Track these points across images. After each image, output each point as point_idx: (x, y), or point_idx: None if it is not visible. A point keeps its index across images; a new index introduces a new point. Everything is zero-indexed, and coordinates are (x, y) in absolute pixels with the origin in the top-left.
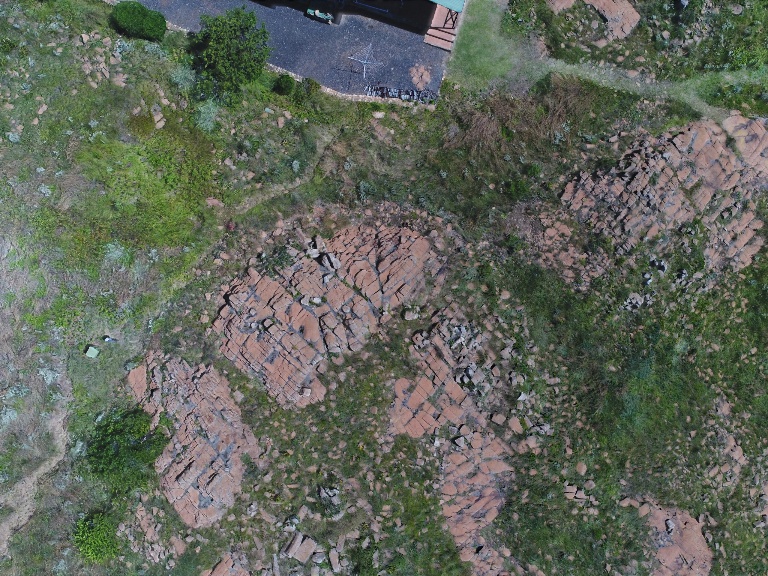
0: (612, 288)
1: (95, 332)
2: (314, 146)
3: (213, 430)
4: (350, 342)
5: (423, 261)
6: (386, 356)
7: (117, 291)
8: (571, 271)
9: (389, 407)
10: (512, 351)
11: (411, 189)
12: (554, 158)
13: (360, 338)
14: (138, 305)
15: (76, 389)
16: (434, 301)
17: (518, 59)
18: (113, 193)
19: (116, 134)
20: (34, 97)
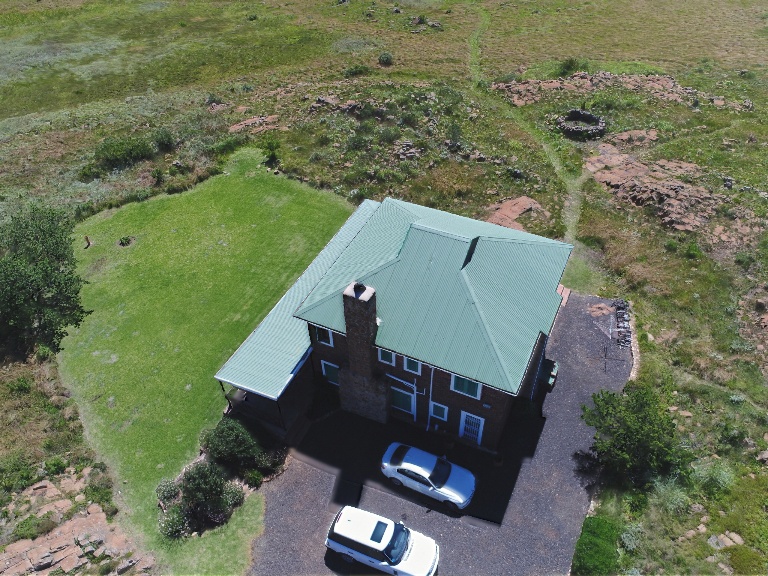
0: (761, 206)
1: None
2: None
3: None
4: None
5: None
6: None
7: None
8: (754, 228)
9: None
10: None
11: None
12: None
13: None
14: None
15: None
16: None
17: None
18: None
19: None
20: None
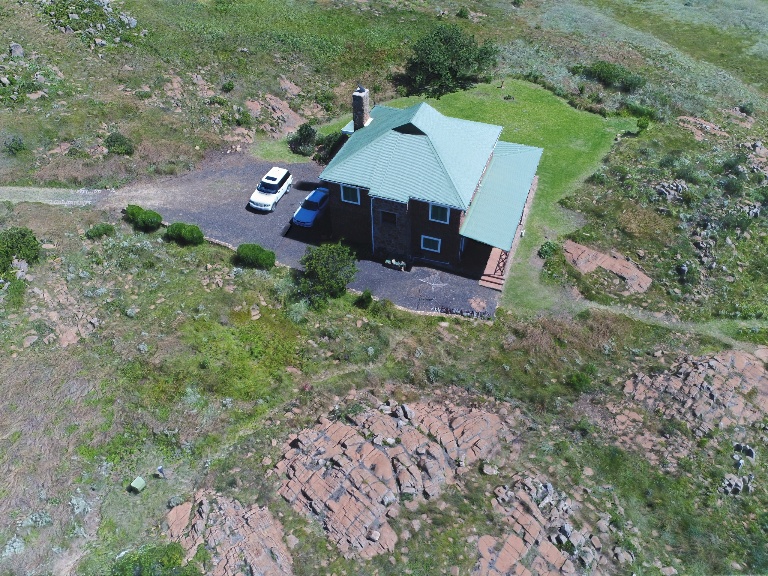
0: (703, 468)
1: (146, 470)
2: (387, 340)
3: (259, 566)
4: (426, 484)
5: (496, 429)
6: (466, 507)
7: (183, 429)
8: (653, 454)
9: (473, 569)
10: (610, 525)
11: (477, 377)
12: (607, 365)
13: (436, 486)
14: (200, 444)
15: (104, 525)
16: (512, 465)
17: (558, 299)
18: (202, 357)
19: (218, 317)
20: (157, 293)
